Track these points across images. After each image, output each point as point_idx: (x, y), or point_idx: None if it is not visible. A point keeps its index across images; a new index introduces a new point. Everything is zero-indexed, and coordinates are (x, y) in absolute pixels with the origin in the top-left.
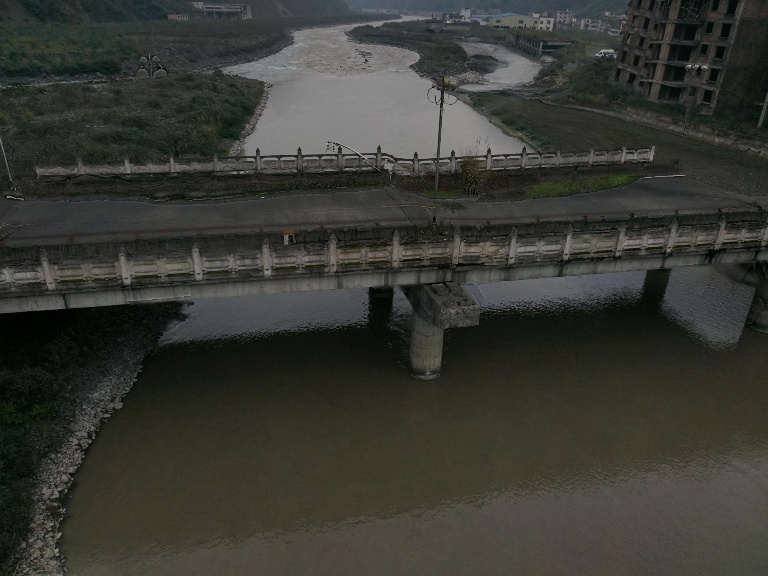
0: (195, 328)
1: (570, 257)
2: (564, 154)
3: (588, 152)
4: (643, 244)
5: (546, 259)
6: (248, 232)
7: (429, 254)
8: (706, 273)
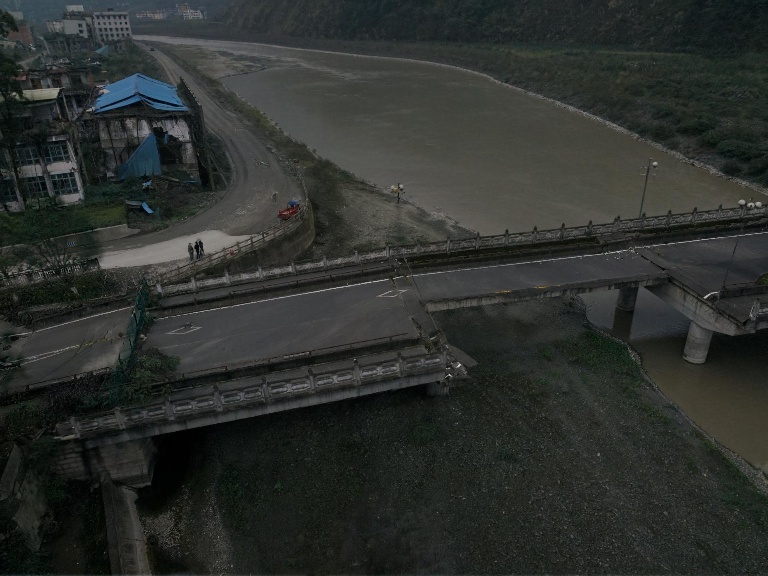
0: None
1: None
2: None
3: None
4: (730, 214)
5: None
6: None
7: None
8: (653, 351)
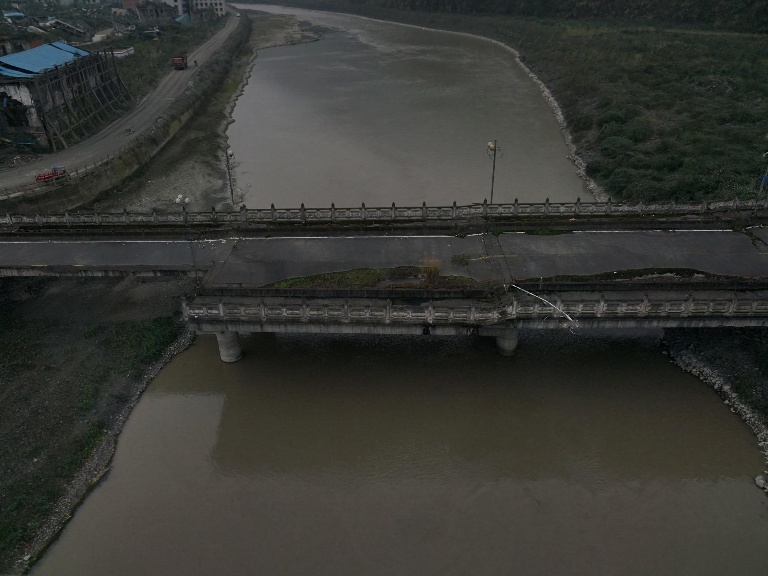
0: (647, 335)
1: (421, 218)
2: (297, 304)
3: (267, 304)
4: (379, 214)
5: None
6: (596, 218)
7: (498, 210)
8: (207, 344)
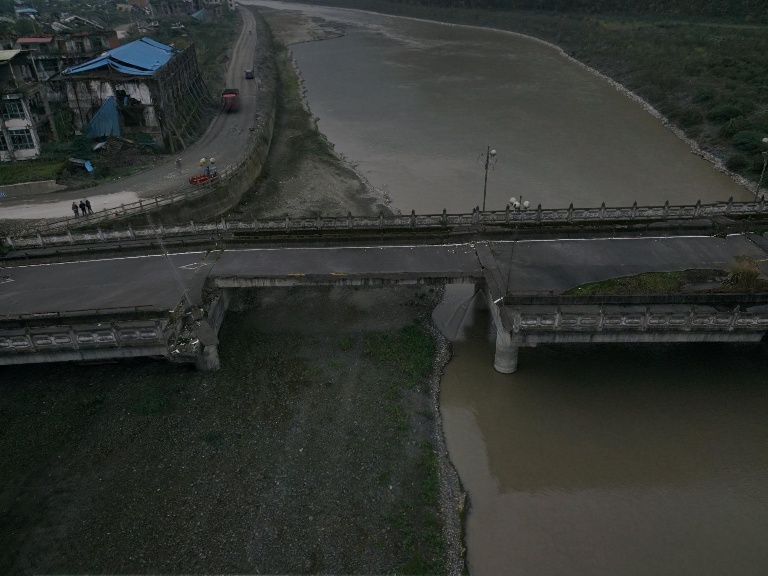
0: None
1: None
2: (639, 313)
3: None
4: (618, 214)
5: (674, 217)
6: None
7: None
8: (469, 354)
